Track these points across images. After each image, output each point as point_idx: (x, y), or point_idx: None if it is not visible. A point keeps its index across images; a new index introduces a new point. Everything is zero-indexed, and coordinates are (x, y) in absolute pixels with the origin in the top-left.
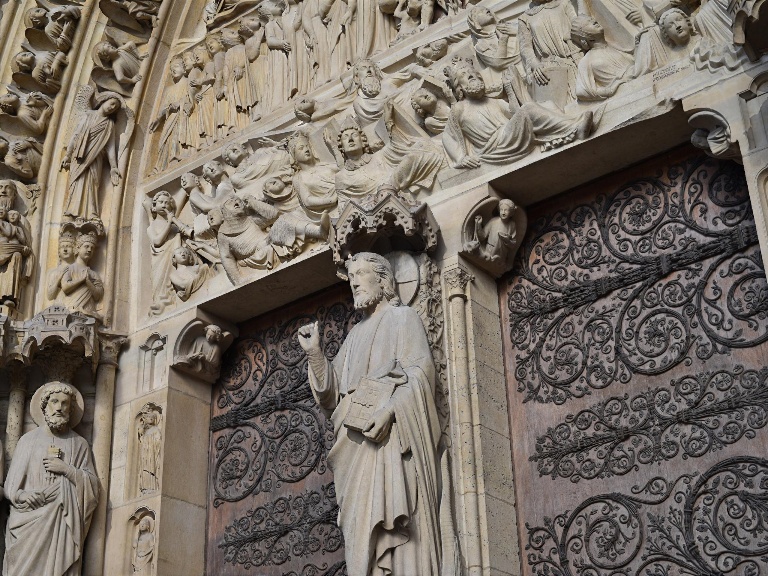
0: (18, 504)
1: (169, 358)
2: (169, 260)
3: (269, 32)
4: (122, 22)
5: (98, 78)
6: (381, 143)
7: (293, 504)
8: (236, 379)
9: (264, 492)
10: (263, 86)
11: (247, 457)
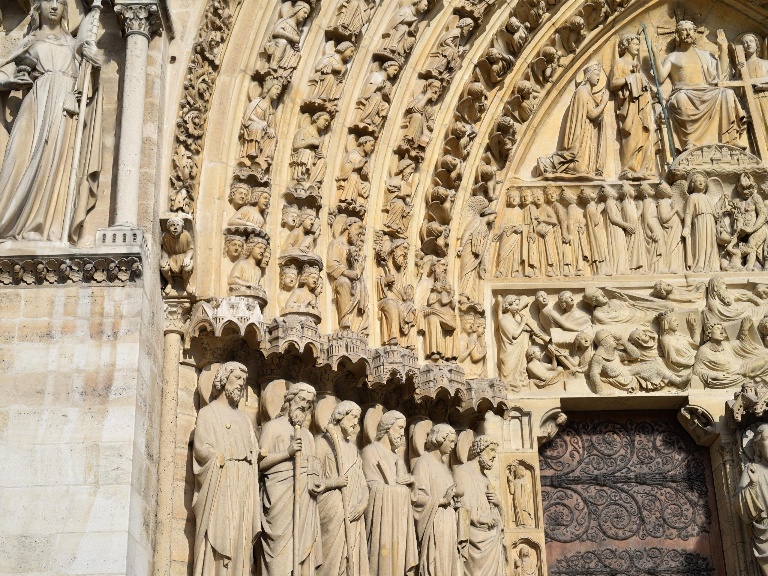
0: (479, 524)
1: (536, 430)
2: (522, 352)
3: (614, 211)
4: (493, 150)
5: (479, 190)
6: (726, 337)
7: (620, 555)
8: (553, 451)
9: (591, 541)
10: (606, 249)
11: (572, 512)
